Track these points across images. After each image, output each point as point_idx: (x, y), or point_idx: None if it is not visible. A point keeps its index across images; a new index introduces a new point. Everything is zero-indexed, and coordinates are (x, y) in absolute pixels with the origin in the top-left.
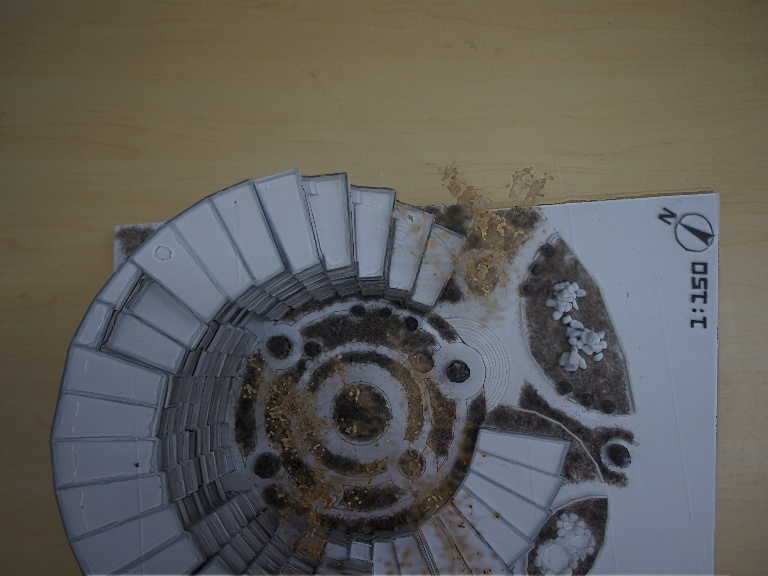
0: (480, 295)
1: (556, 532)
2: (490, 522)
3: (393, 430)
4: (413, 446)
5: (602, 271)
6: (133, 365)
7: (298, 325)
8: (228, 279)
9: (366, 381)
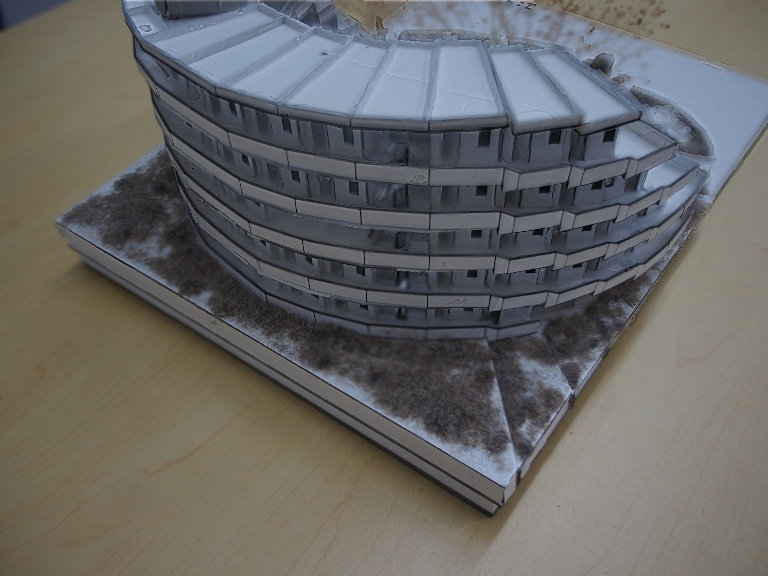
0: None
1: None
2: None
3: None
4: None
5: (447, 26)
6: (221, 21)
7: None
8: None
9: None
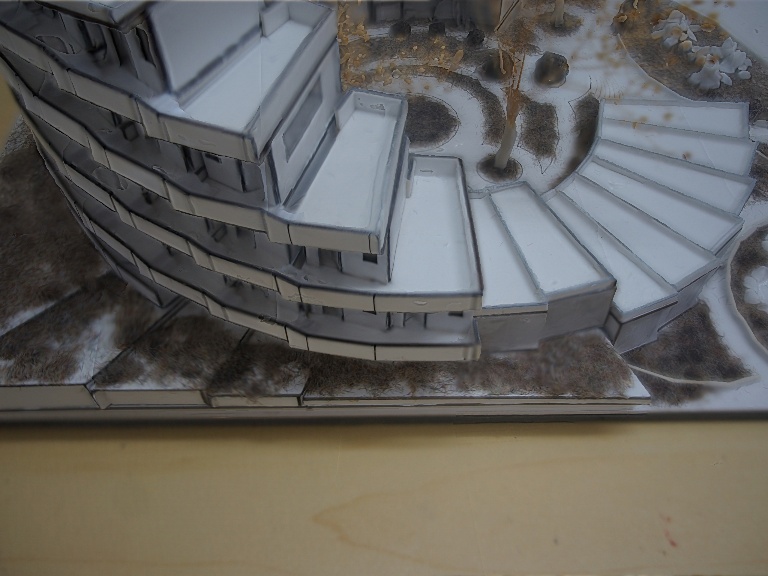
0: (561, 36)
1: (767, 257)
2: (651, 200)
3: (463, 135)
4: (497, 150)
5: (713, 15)
6: None
7: None
8: None
9: (416, 92)
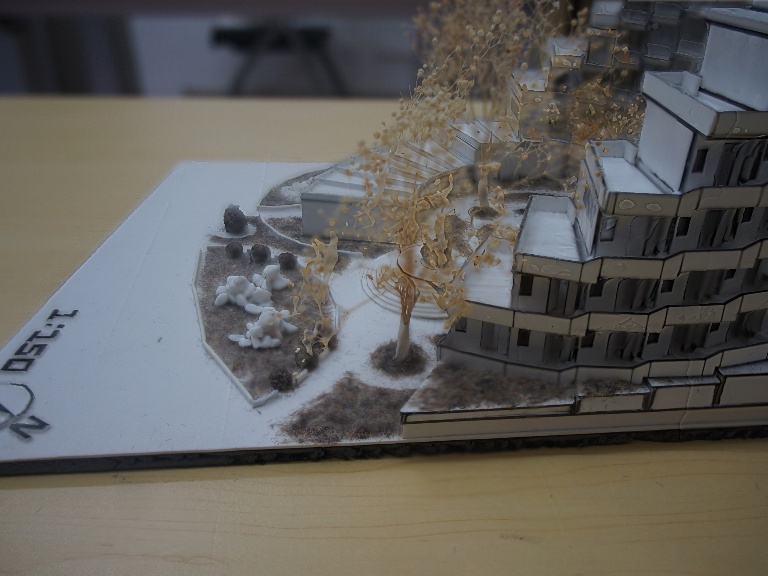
0: None
1: None
2: None
3: None
4: (486, 222)
5: (191, 364)
6: None
7: None
8: None
9: None
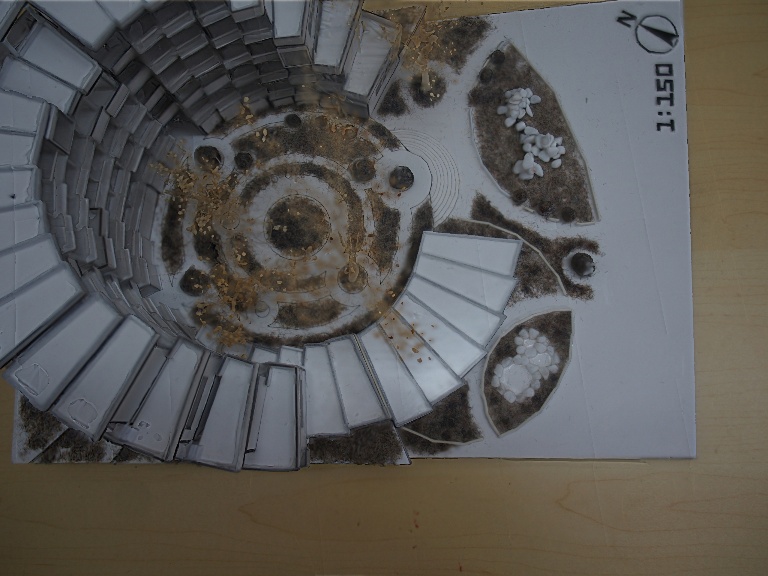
0: (426, 106)
1: (515, 349)
2: (437, 329)
3: (332, 243)
4: None
5: (558, 77)
6: (12, 94)
7: (229, 138)
8: (118, 5)
9: (302, 194)
